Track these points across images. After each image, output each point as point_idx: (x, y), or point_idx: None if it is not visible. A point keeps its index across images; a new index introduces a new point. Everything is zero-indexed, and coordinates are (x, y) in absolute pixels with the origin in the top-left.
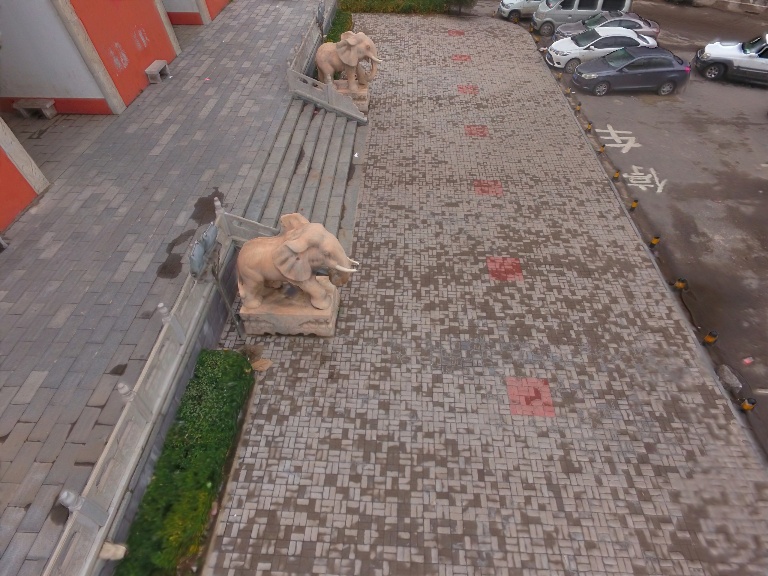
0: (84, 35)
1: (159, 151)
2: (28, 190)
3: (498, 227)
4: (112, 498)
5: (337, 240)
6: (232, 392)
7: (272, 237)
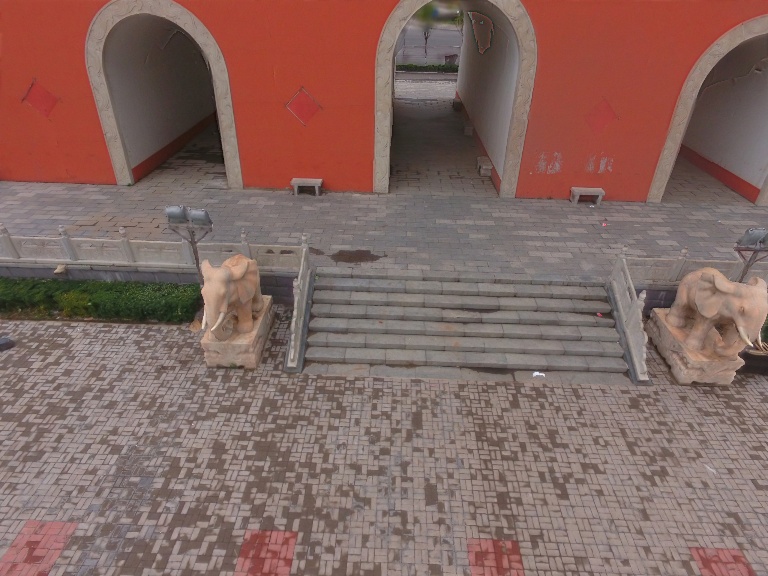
0: (521, 132)
1: (443, 222)
2: (369, 185)
3: (371, 566)
4: (86, 259)
5: (214, 295)
6: (155, 303)
7: (239, 263)
